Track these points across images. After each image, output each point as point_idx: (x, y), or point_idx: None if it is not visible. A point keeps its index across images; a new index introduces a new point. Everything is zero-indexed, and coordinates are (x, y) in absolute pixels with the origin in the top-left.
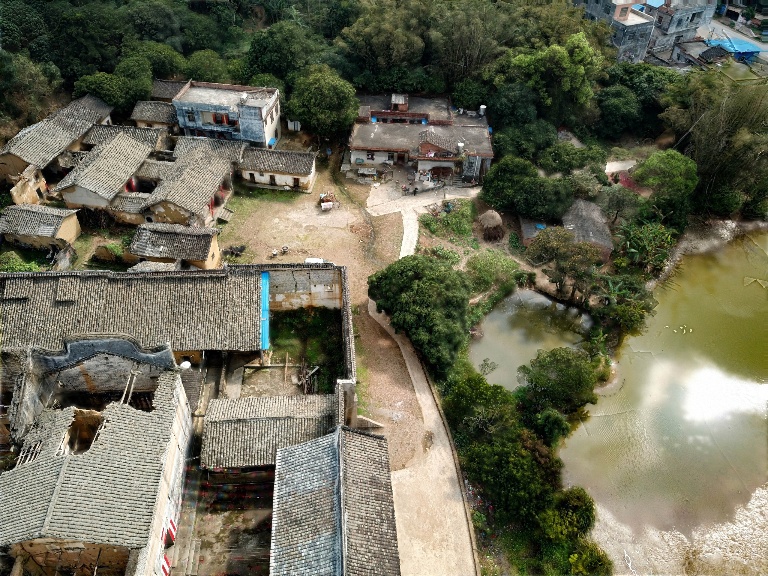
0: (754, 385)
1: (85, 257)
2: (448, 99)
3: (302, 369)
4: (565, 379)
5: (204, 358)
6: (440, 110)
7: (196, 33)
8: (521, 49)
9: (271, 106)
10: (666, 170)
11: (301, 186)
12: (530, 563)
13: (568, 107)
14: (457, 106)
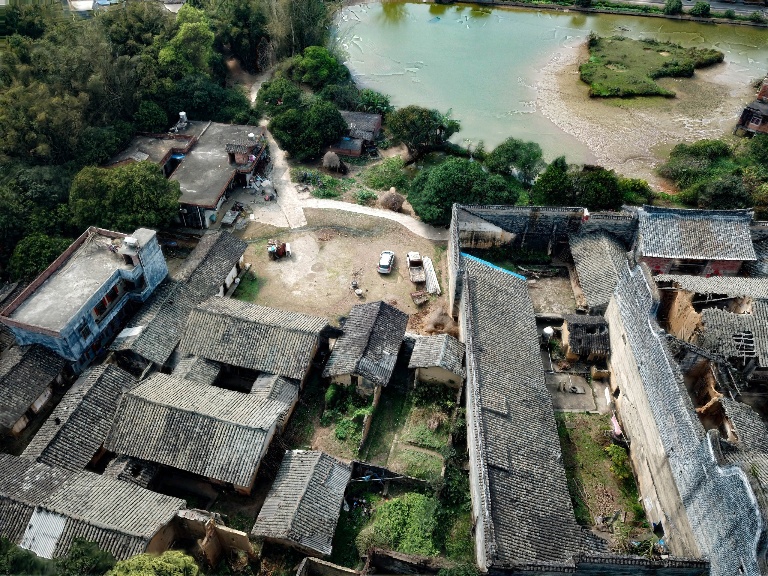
0: (491, 112)
1: None
2: (140, 134)
3: (525, 273)
4: (535, 147)
5: None
6: (160, 143)
7: None
8: (151, 49)
9: None
10: (323, 60)
11: (241, 267)
12: None
13: None
14: (160, 131)
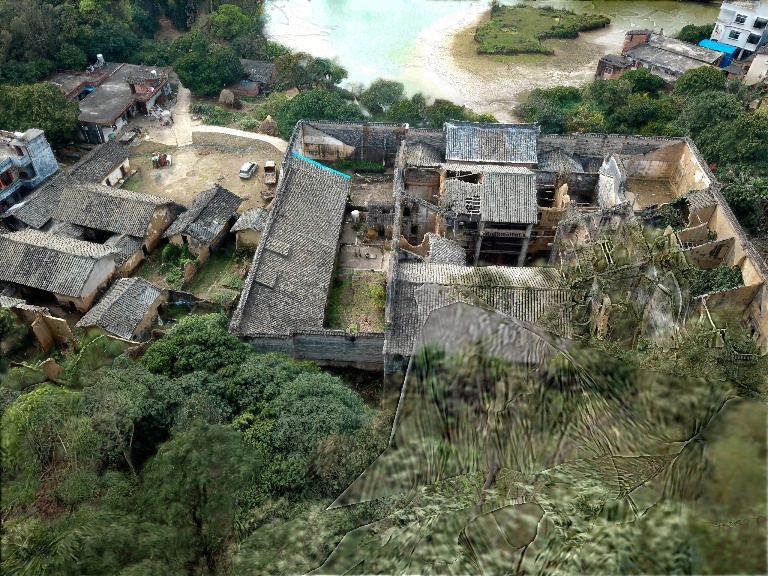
0: (386, 65)
1: None
2: (62, 72)
3: (358, 178)
4: (398, 85)
5: None
6: (77, 78)
7: None
8: None
9: None
10: (235, 17)
11: (127, 172)
12: None
13: None
14: (79, 70)
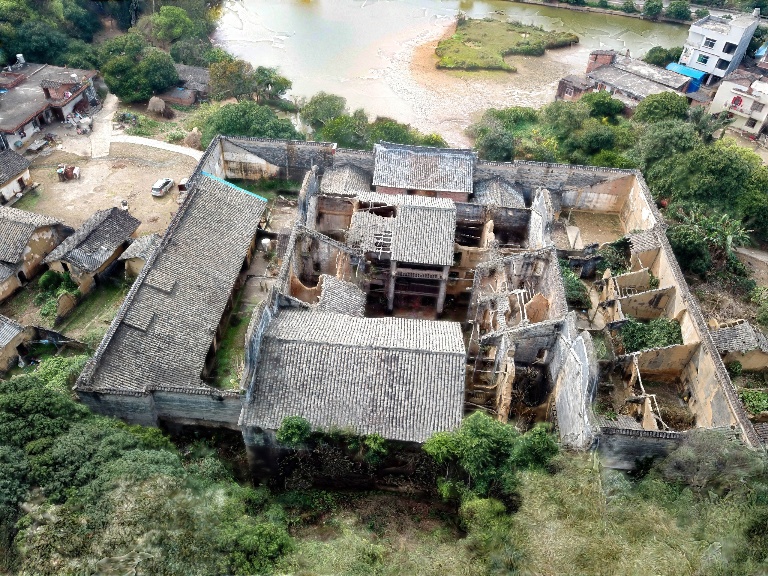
0: (339, 76)
1: None
2: None
3: (281, 201)
4: (339, 100)
5: (256, 238)
6: None
7: None
8: None
9: None
10: (177, 19)
11: (27, 185)
12: None
13: None
14: None
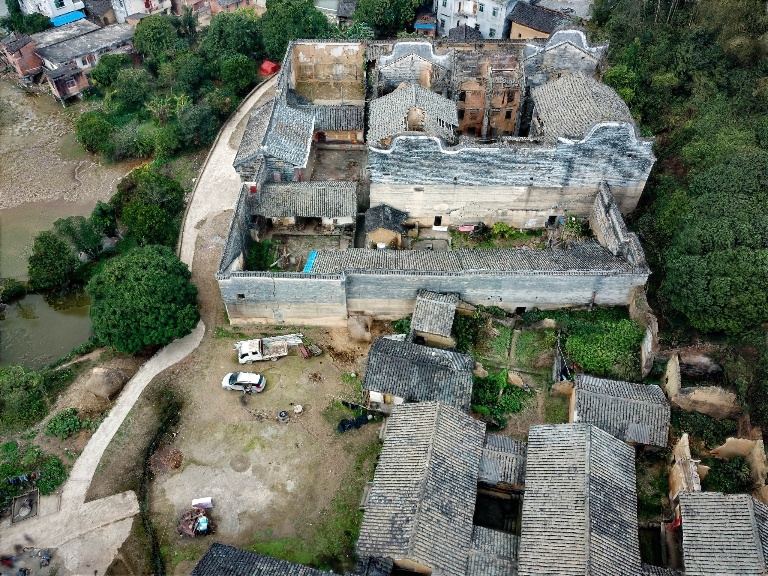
0: None
1: (542, 398)
2: None
3: None
4: (72, 219)
5: None
6: None
7: None
8: None
9: None
10: None
11: None
12: None
13: None
14: None
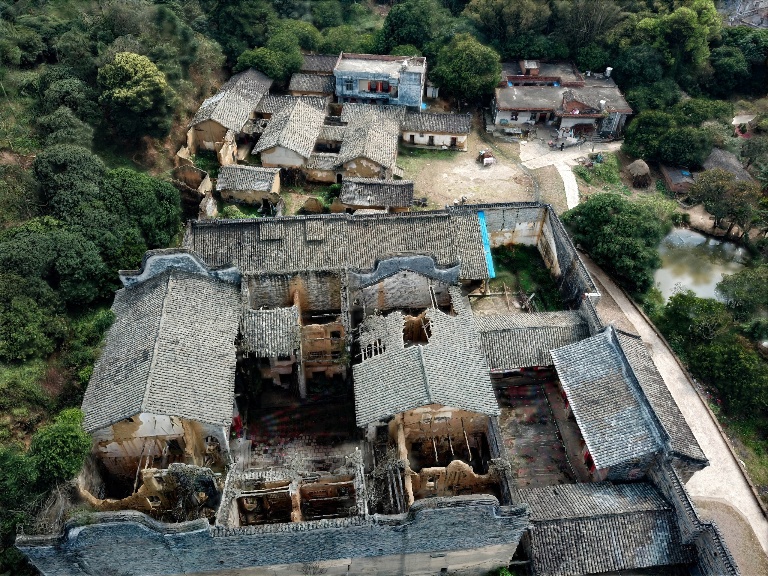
0: None
1: (291, 210)
2: (571, 64)
3: (522, 295)
4: (764, 293)
5: None
6: (568, 73)
7: (323, 11)
8: (645, 13)
9: (423, 73)
10: None
11: (457, 145)
12: (763, 445)
13: (686, 67)
14: (582, 69)
